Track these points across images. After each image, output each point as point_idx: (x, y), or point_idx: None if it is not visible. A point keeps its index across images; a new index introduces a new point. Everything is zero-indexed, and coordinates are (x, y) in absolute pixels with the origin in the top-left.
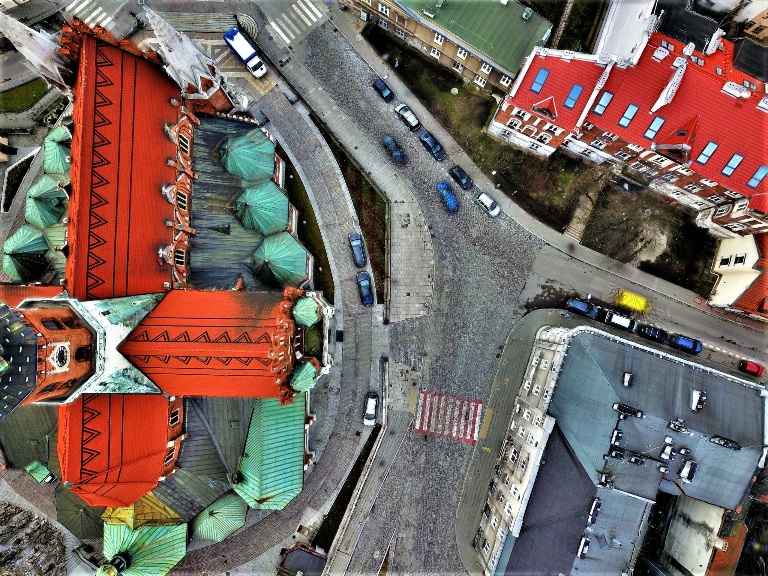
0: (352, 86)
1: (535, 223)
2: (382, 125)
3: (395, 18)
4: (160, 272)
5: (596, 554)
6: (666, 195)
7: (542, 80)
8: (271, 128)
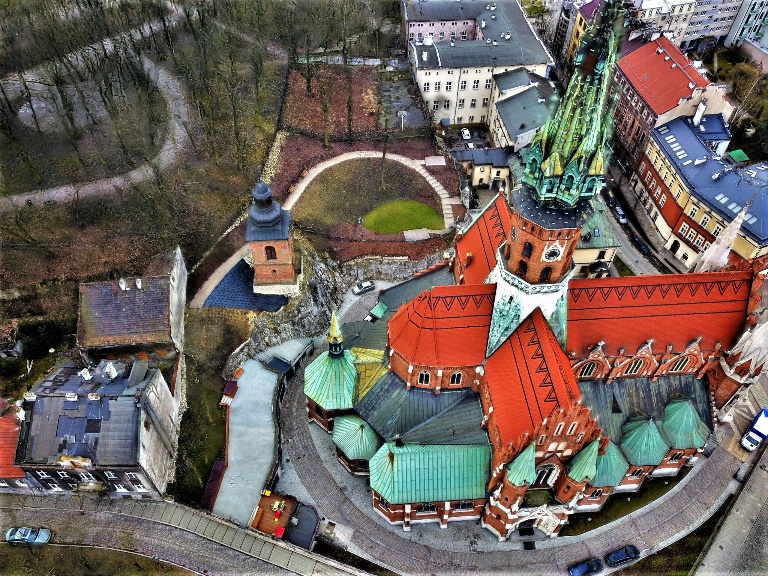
0: None
1: None
2: (758, 574)
3: None
4: (582, 348)
5: None
6: None
7: None
8: (702, 460)
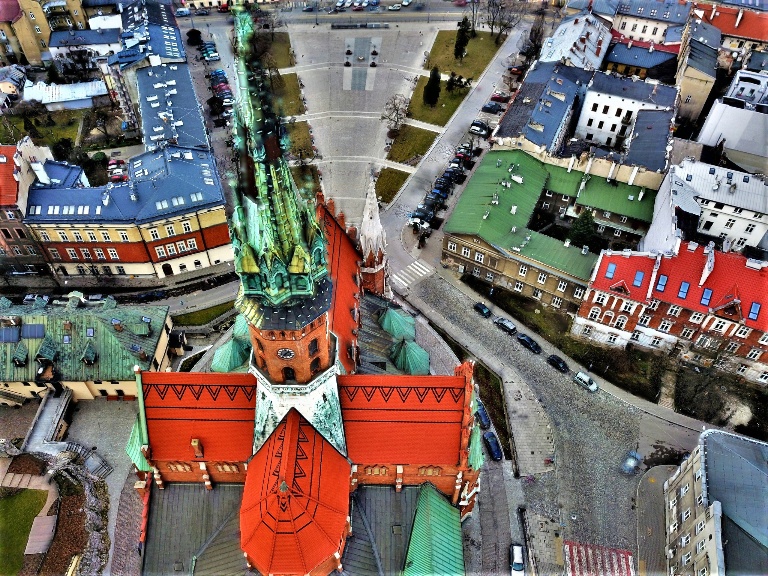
0: (458, 309)
1: (630, 396)
2: (485, 332)
3: (488, 263)
4: (348, 363)
5: None
6: (733, 374)
7: (612, 270)
8: None
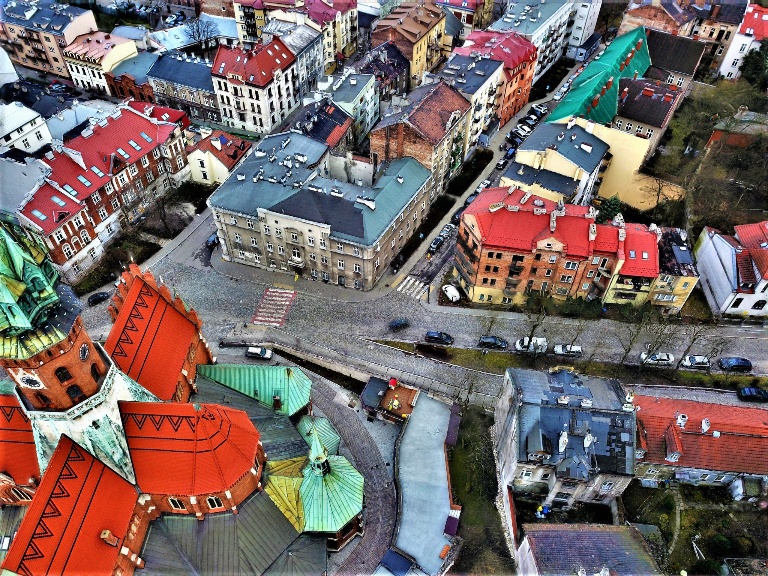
0: None
1: (149, 261)
2: None
3: None
4: None
5: (344, 193)
6: (155, 200)
7: (39, 214)
8: None
